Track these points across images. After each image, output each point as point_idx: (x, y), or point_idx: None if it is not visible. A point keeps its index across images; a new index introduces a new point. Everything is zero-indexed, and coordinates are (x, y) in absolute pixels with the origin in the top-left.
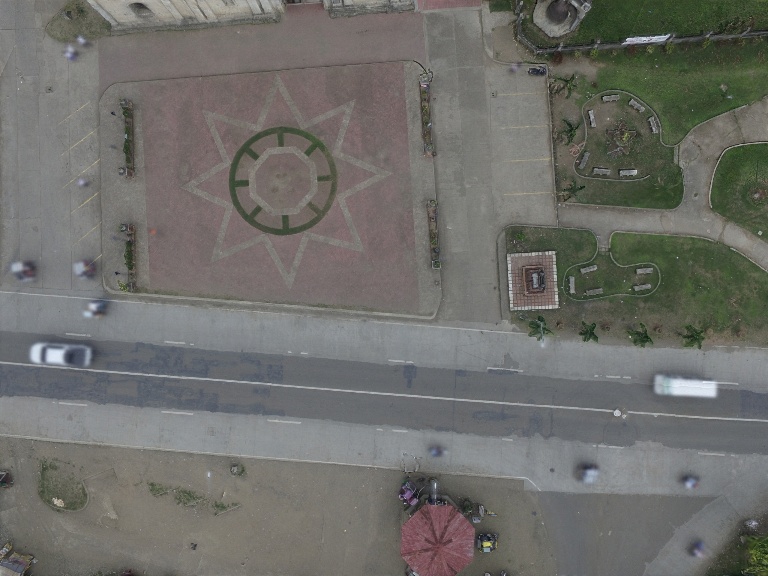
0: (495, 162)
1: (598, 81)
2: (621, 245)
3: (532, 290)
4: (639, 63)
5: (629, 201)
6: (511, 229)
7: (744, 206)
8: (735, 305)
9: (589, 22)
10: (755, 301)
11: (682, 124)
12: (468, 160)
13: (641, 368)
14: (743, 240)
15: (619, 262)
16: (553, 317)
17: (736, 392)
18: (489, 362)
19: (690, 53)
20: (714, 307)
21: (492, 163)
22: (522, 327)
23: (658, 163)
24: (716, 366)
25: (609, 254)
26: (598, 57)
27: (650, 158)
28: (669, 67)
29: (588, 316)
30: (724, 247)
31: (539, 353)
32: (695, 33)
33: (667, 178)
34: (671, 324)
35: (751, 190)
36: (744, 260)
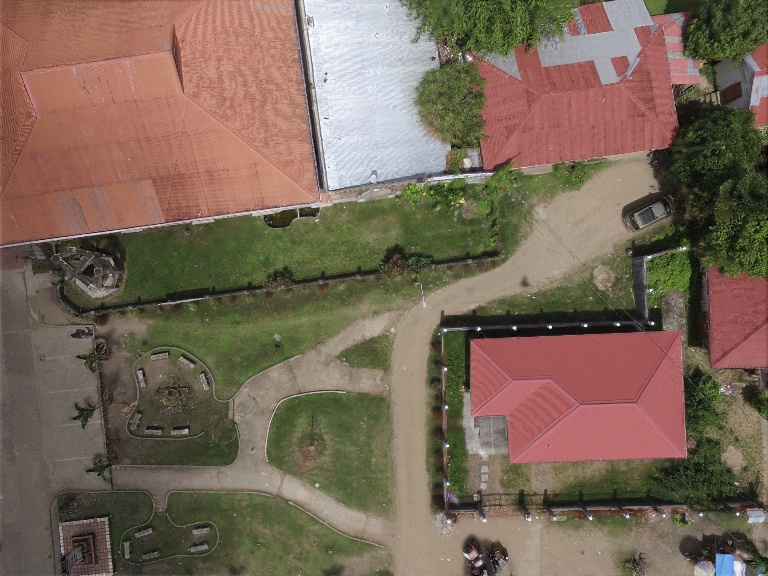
0: (45, 427)
1: (148, 338)
2: (177, 505)
3: None
4: (189, 318)
5: (184, 459)
6: (64, 496)
7: (300, 458)
8: (294, 561)
9: (134, 280)
10: (315, 555)
11: (235, 378)
12: (17, 427)
13: None
14: (301, 492)
15: (176, 522)
16: None
17: None
18: None
19: (241, 304)
20: (273, 564)
21: (42, 429)
22: None
23: (212, 419)
24: None
25: (166, 515)
26: (147, 314)
27: (205, 414)
28: (220, 320)
29: None
30: (282, 501)
31: None
32: (243, 285)
33: (221, 434)
34: None
35: (306, 442)
36: (302, 513)
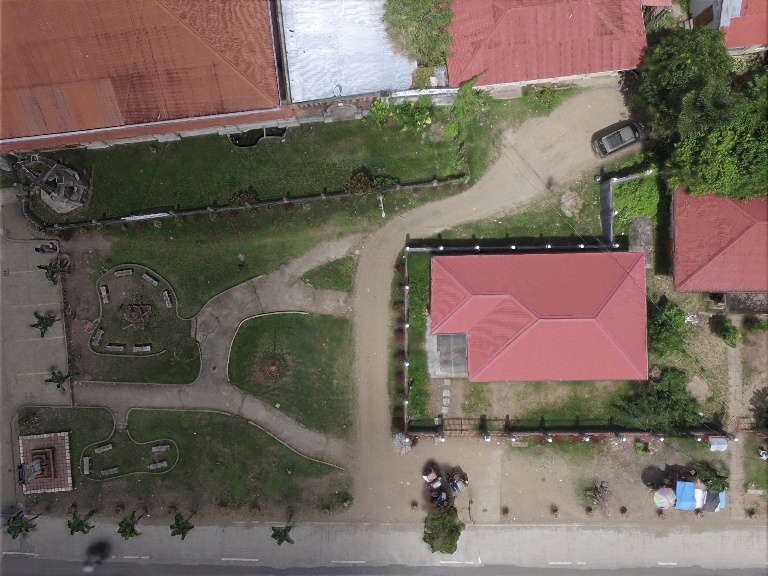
0: (8, 342)
1: (112, 255)
2: (138, 422)
3: (36, 476)
4: (153, 235)
5: (145, 377)
6: (25, 410)
7: (262, 378)
8: (253, 480)
9: (99, 196)
10: (274, 475)
11: (198, 296)
12: None
13: (159, 547)
14: (262, 413)
15: (136, 439)
16: (69, 498)
17: (256, 568)
18: (4, 547)
19: (206, 223)
20: (232, 483)
21: (5, 343)
22: (37, 510)
23: (175, 337)
24: (235, 543)
25: (126, 432)
26: (111, 231)
27: (167, 332)
28: (185, 238)
29: (105, 496)
30: (242, 421)
31: (55, 536)
32: (208, 203)
33: (183, 352)
34: (187, 502)
35: (268, 362)
36: (262, 433)
